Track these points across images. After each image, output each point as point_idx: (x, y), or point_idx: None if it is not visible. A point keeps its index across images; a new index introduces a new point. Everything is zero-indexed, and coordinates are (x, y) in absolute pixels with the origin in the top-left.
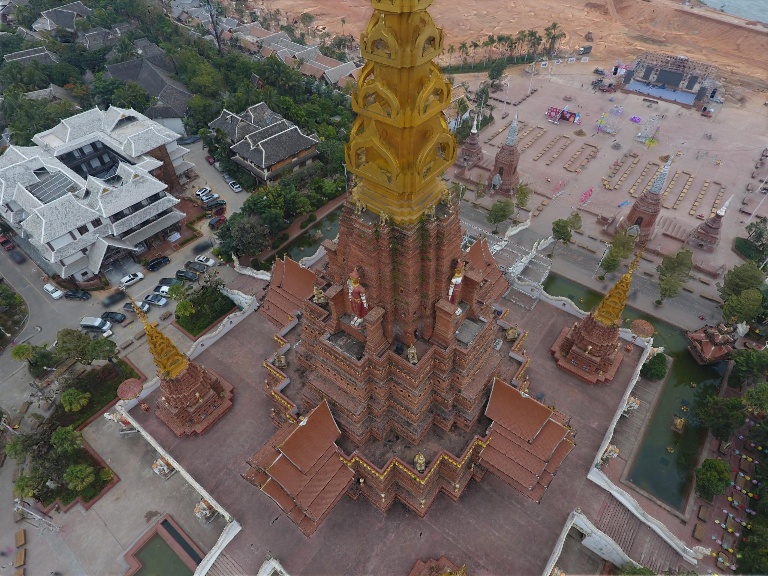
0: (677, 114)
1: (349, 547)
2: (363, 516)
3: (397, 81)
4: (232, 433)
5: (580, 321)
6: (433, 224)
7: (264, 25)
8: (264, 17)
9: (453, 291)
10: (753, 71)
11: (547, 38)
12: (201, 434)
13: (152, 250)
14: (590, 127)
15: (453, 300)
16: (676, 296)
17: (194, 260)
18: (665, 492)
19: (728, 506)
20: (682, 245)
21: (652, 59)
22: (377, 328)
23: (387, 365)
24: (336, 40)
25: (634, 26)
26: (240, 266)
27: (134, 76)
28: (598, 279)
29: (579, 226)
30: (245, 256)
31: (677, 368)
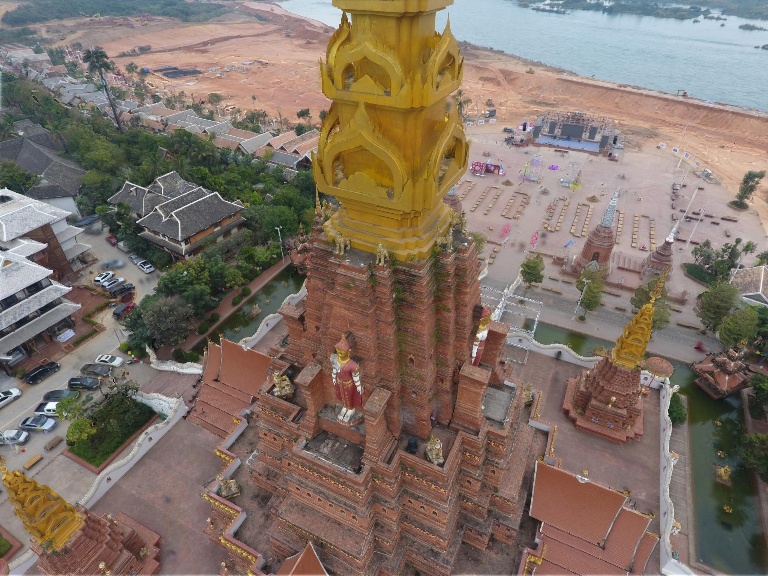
0: (588, 160)
1: None
2: None
3: (395, 40)
4: None
5: (581, 369)
6: (450, 257)
7: (168, 107)
8: (168, 99)
9: (477, 351)
10: (637, 122)
11: None
12: None
13: (34, 356)
14: (515, 177)
15: (476, 363)
16: (665, 327)
17: (94, 361)
18: (744, 568)
19: None
20: (639, 276)
21: (554, 115)
22: (379, 420)
23: (399, 473)
24: (248, 115)
25: (526, 93)
26: (158, 361)
27: (12, 157)
28: (579, 320)
29: (542, 267)
30: (164, 347)
31: (693, 407)
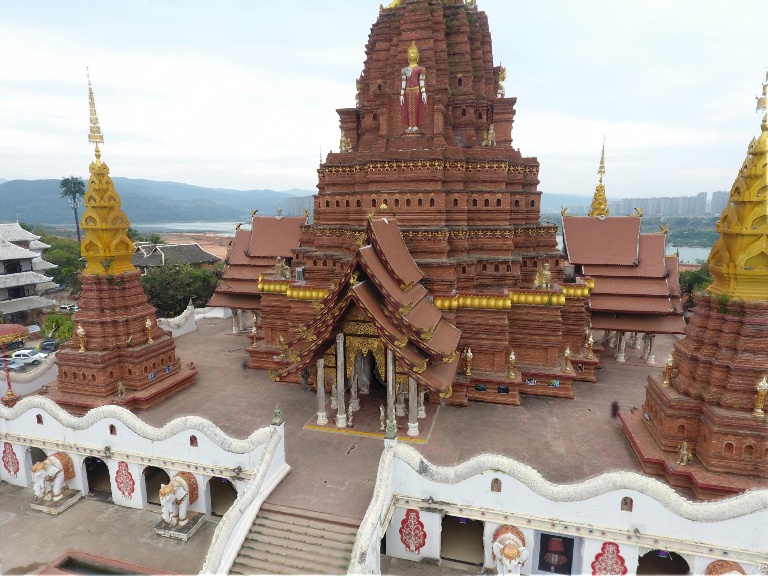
0: None
1: (505, 441)
2: (493, 415)
3: None
4: (207, 399)
5: None
6: None
7: None
8: None
9: None
10: None
11: None
12: (145, 408)
13: None
14: None
15: None
16: None
17: None
18: None
19: None
20: None
21: None
22: (442, 123)
23: (465, 161)
24: None
25: None
26: None
27: None
28: None
29: None
30: None
31: None
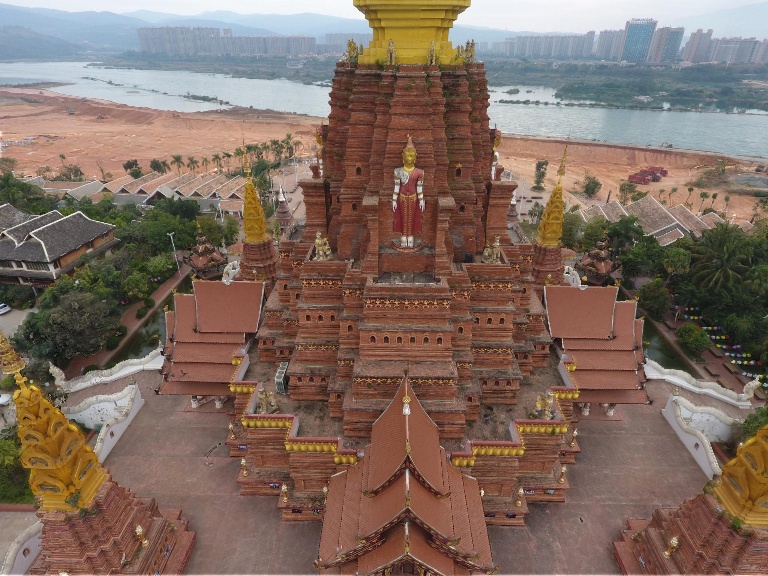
0: None
1: None
2: (506, 549)
3: None
4: None
5: None
6: None
7: None
8: None
9: None
10: None
11: (287, 147)
12: None
13: None
14: None
15: None
16: None
17: None
18: None
19: (715, 359)
20: None
21: None
22: None
23: None
24: (63, 171)
25: None
26: (68, 381)
27: None
28: None
29: None
30: (65, 373)
31: None
